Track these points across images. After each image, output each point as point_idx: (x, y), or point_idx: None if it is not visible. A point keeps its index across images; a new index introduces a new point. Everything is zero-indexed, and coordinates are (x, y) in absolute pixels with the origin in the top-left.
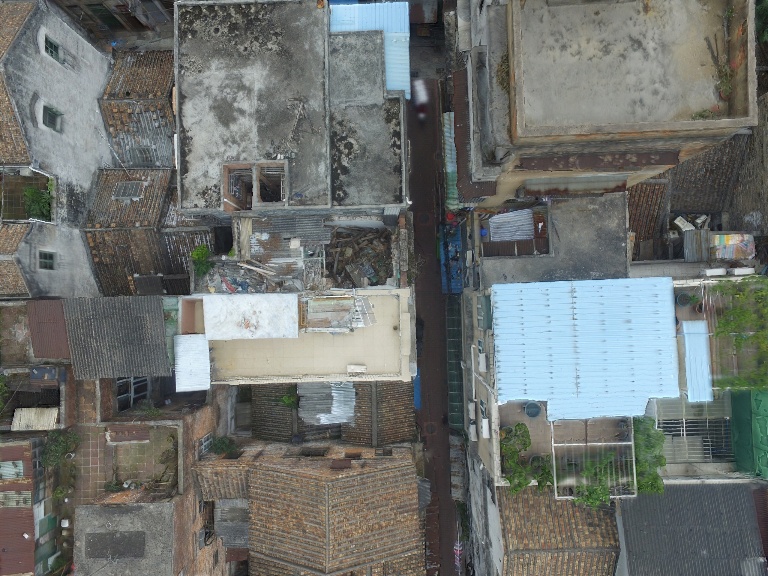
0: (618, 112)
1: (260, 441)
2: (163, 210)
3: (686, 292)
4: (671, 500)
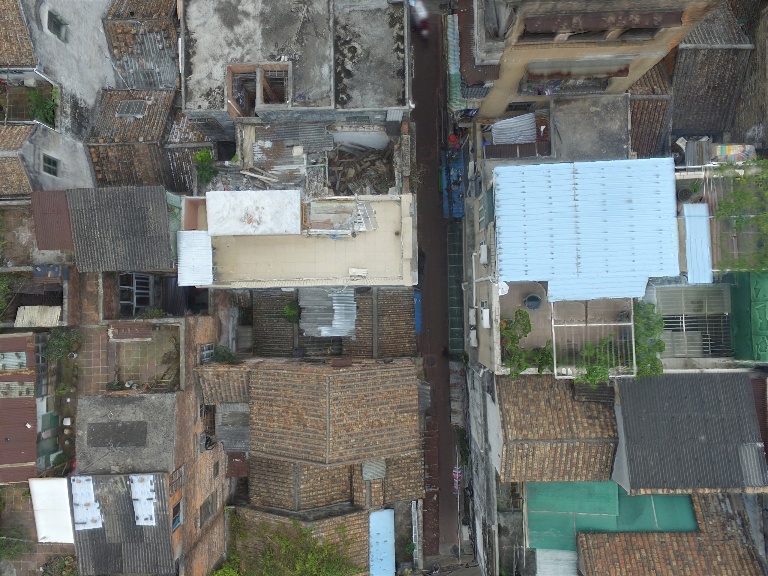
0: None
1: (261, 357)
2: (166, 127)
3: (687, 187)
4: (670, 388)
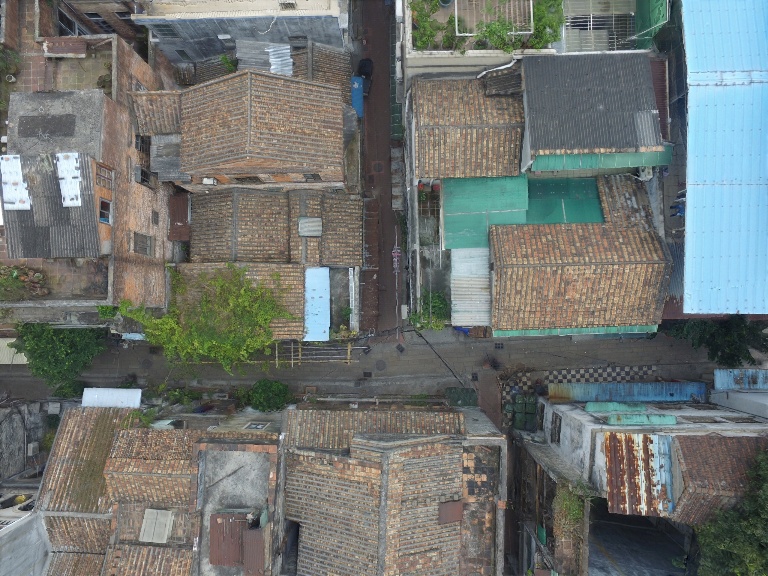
0: None
1: None
2: None
3: None
4: (572, 67)
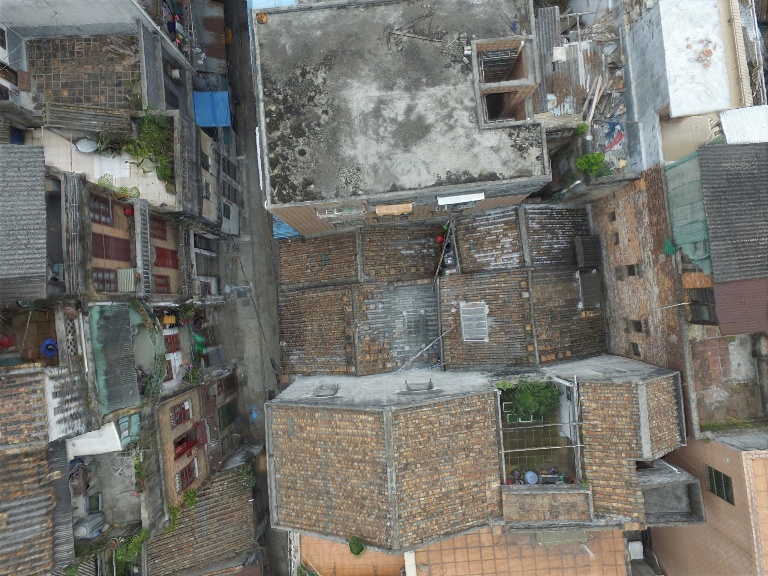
0: None
1: None
2: None
3: None
4: None
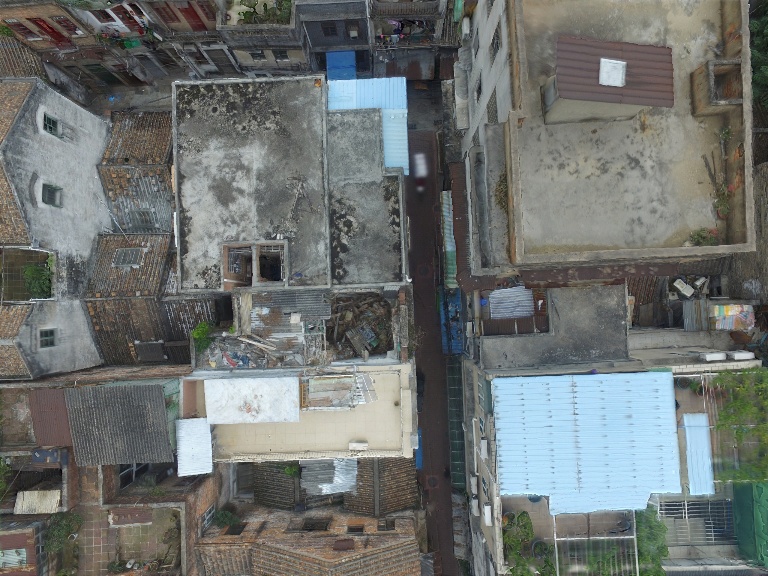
0: (616, 230)
1: (262, 508)
2: (163, 278)
3: None
4: None
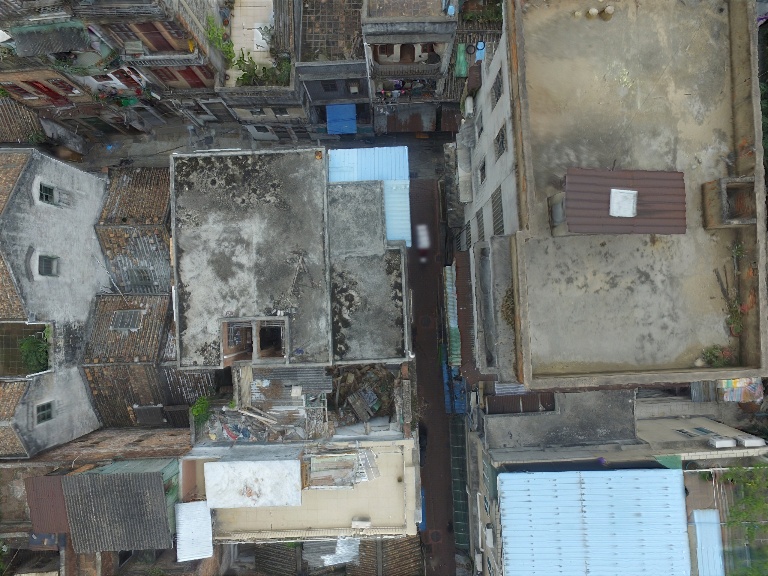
0: (626, 347)
1: None
2: (162, 342)
3: (695, 461)
4: None
